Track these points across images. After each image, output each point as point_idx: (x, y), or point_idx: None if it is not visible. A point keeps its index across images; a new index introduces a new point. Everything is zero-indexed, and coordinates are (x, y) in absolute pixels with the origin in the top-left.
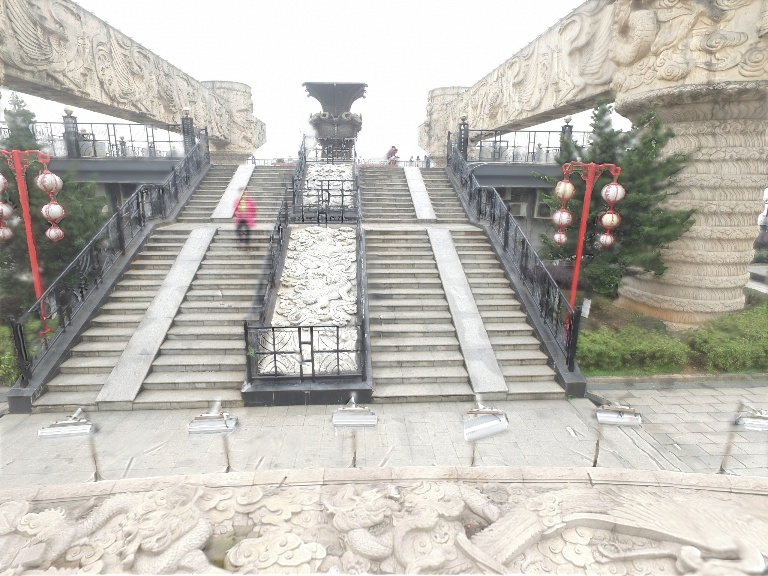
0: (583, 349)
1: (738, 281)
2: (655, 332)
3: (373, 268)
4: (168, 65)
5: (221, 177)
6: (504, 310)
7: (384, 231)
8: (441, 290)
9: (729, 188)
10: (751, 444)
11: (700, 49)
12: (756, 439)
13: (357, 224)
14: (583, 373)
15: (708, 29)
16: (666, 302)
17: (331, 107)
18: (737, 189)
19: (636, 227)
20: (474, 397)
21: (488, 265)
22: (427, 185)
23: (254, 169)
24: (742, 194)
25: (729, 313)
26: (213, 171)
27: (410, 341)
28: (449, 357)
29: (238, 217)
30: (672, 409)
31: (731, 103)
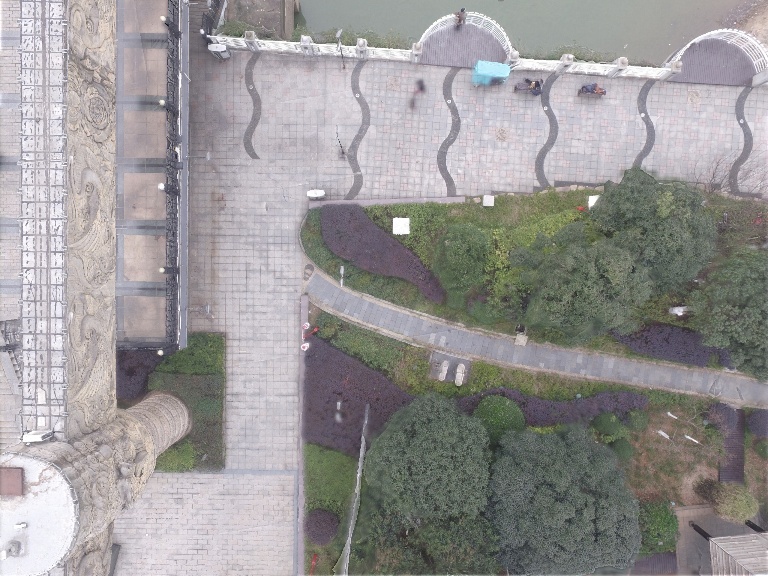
0: None
1: None
2: None
3: None
4: None
5: None
6: None
7: None
8: None
9: None
10: None
11: None
12: None
13: None
14: None
15: None
16: None
17: None
18: None
19: None
20: None
21: None
22: (11, 351)
23: None
24: None
25: None
26: None
27: None
28: None
29: None
30: None
31: None
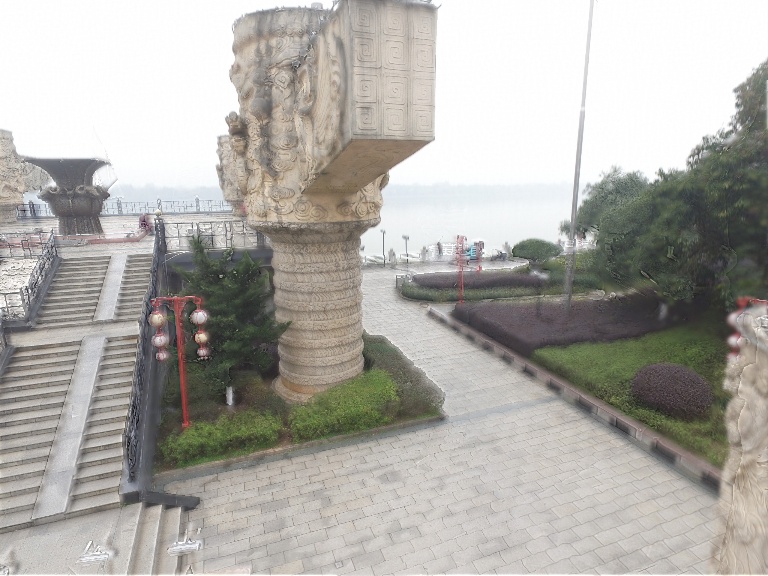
0: (182, 446)
1: (343, 358)
2: (265, 413)
3: (3, 393)
4: None
5: None
6: (115, 422)
7: (36, 346)
8: (61, 410)
9: (320, 293)
10: (260, 515)
11: (270, 197)
12: (269, 509)
13: None
14: (190, 463)
15: (272, 183)
16: (296, 379)
17: (64, 180)
18: (326, 293)
19: (225, 340)
20: (32, 523)
21: (125, 373)
22: (126, 276)
23: None
24: (331, 296)
25: (342, 382)
26: None
27: None
28: (28, 485)
29: None
30: (234, 489)
31: (302, 235)
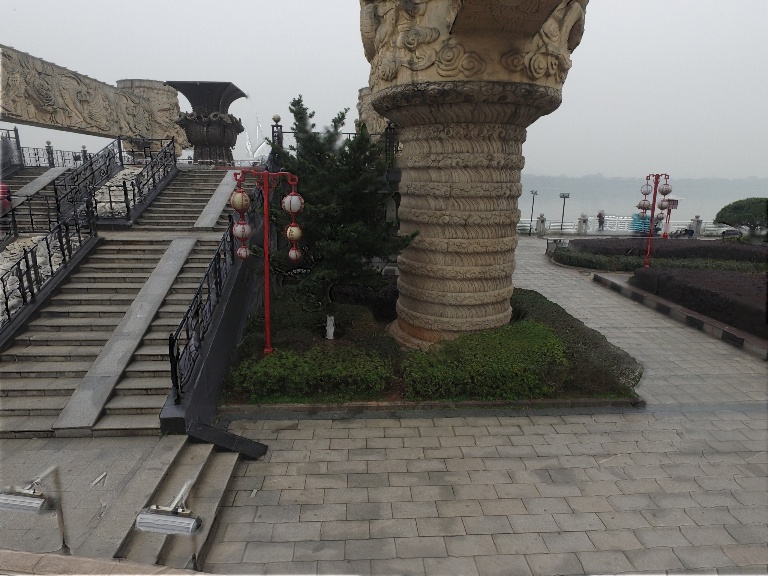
0: (258, 374)
1: (485, 298)
2: (372, 354)
3: (78, 282)
4: (44, 63)
5: (20, 181)
6: (184, 330)
7: (126, 241)
8: None
9: (461, 198)
10: (344, 490)
11: (404, 46)
12: (359, 484)
13: (91, 233)
14: (267, 400)
15: (408, 24)
16: (417, 319)
17: (201, 107)
18: (470, 199)
19: None
20: (53, 433)
21: None
22: None
23: (64, 172)
24: (476, 204)
25: None
26: (20, 174)
27: (39, 366)
28: (64, 386)
29: (2, 224)
30: (315, 445)
31: (443, 105)
